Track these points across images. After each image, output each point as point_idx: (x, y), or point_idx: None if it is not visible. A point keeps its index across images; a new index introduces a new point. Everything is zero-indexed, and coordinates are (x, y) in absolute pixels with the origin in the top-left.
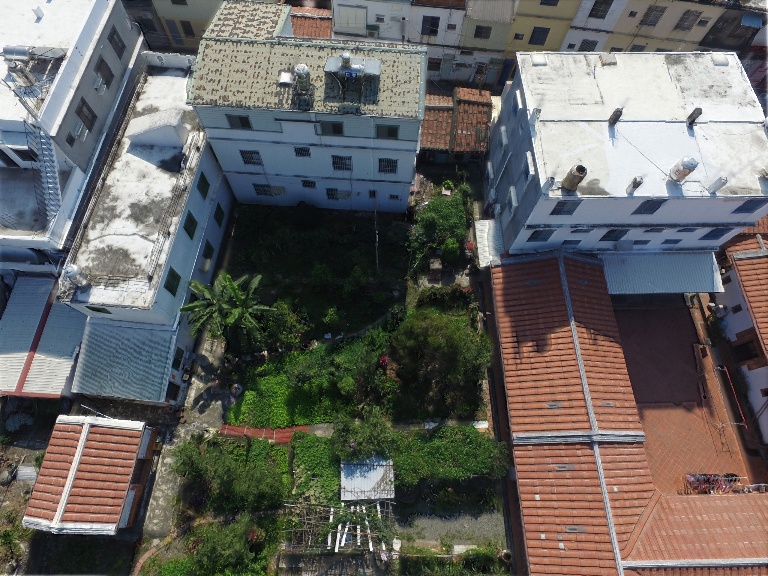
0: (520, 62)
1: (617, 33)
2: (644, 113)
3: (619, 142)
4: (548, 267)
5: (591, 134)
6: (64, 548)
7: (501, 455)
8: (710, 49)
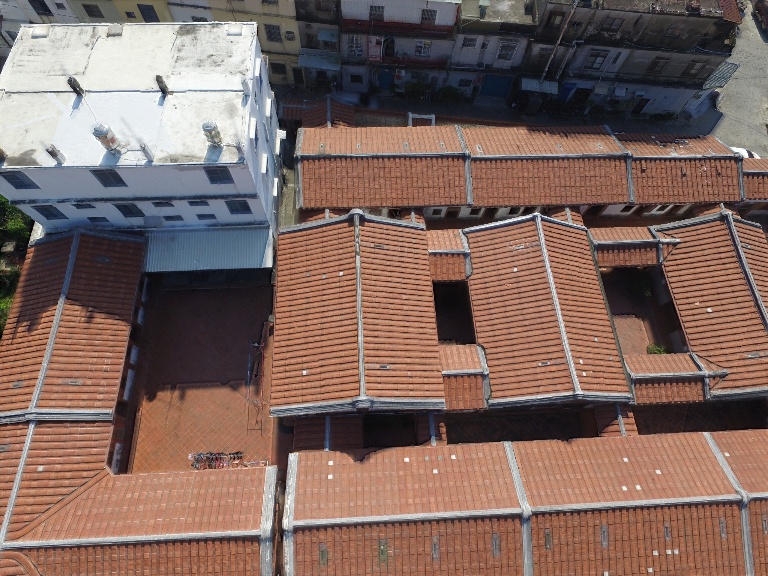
0: (19, 34)
1: (214, 9)
2: (121, 83)
3: (79, 112)
4: (66, 245)
5: (54, 105)
6: None
7: None
8: (310, 24)
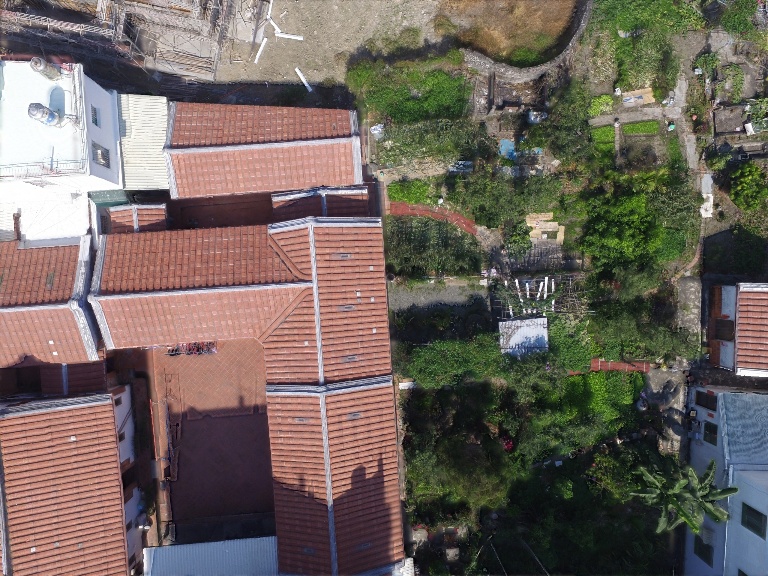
0: None
1: None
2: None
3: None
4: (349, 567)
5: None
6: (763, 266)
7: (399, 363)
8: None
